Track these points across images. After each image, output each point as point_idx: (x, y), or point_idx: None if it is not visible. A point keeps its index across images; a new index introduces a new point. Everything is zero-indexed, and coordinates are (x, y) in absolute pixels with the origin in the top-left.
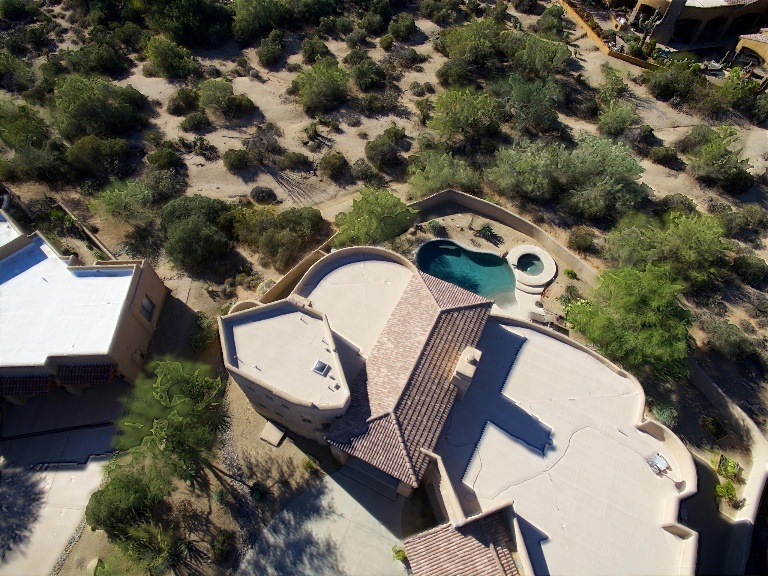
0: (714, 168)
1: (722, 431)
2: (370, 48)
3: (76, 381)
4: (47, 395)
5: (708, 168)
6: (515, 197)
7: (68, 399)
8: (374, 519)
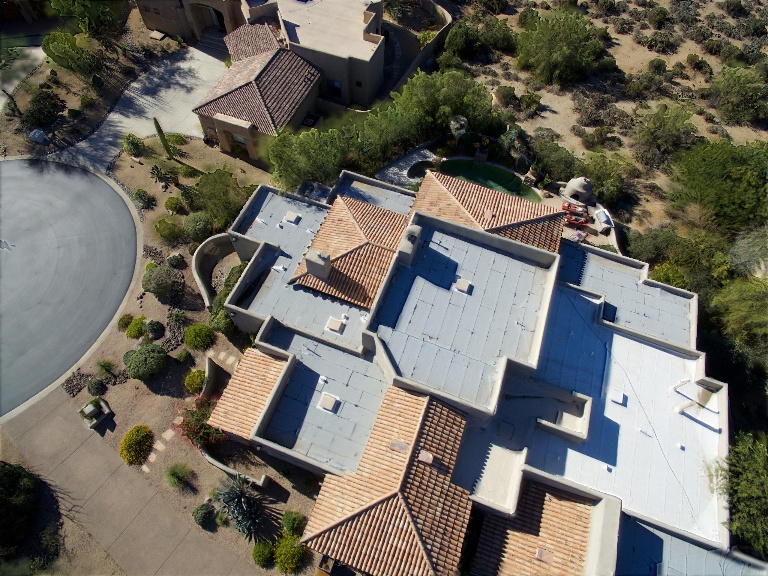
0: None
1: (433, 24)
2: None
3: None
4: (10, 24)
5: None
6: None
7: (24, 25)
8: (217, 60)
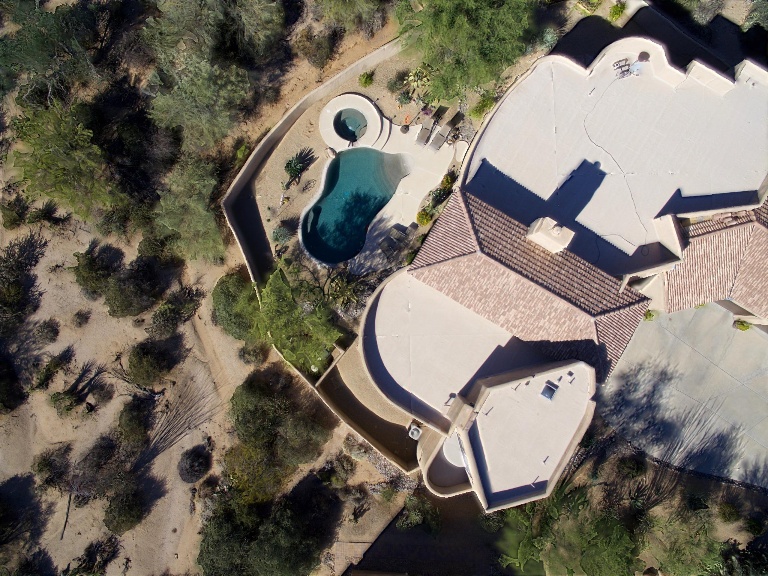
0: None
1: None
2: None
3: None
4: None
5: None
6: (231, 116)
7: None
8: None
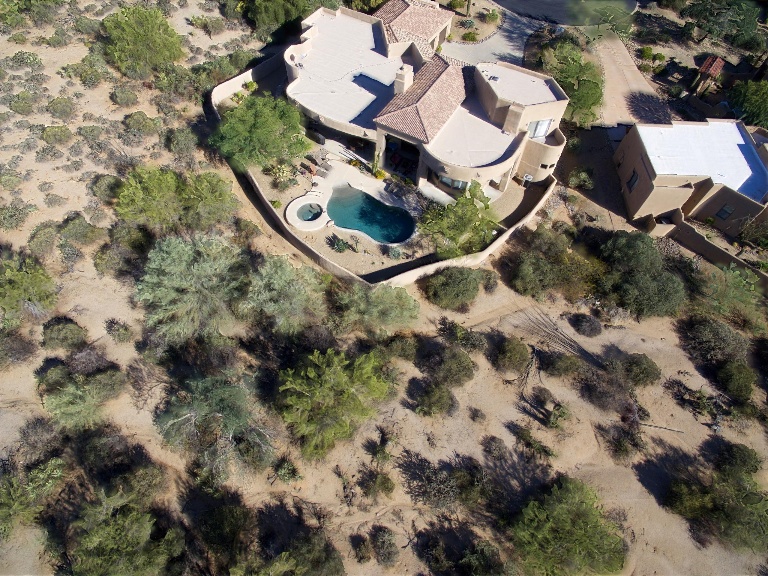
0: None
1: None
2: None
3: None
4: None
5: (43, 287)
6: None
7: None
8: None
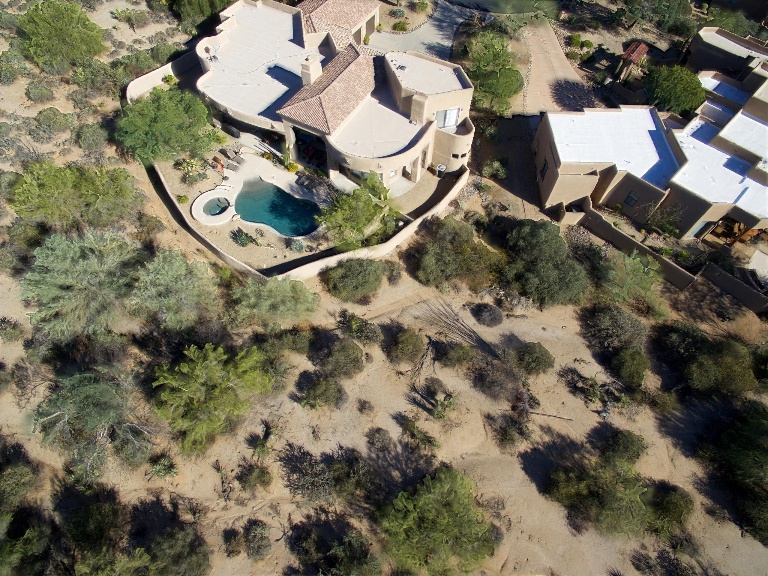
0: None
1: None
2: None
3: None
4: None
5: None
6: None
7: None
8: None
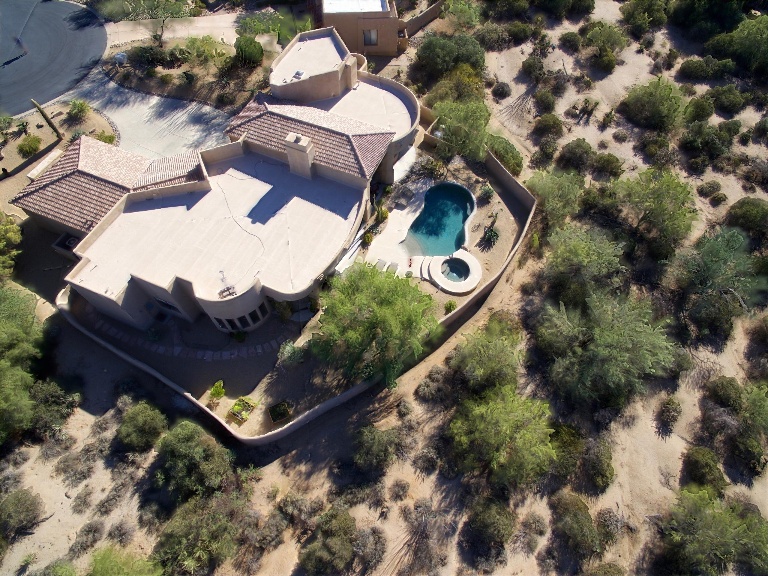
0: (685, 522)
1: (277, 416)
2: (766, 145)
3: (314, 14)
4: None
5: (683, 514)
6: None
7: None
8: None
